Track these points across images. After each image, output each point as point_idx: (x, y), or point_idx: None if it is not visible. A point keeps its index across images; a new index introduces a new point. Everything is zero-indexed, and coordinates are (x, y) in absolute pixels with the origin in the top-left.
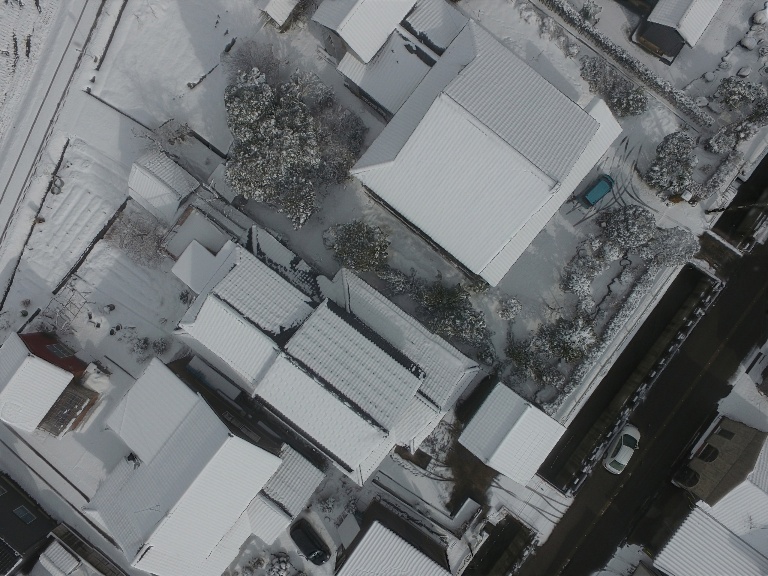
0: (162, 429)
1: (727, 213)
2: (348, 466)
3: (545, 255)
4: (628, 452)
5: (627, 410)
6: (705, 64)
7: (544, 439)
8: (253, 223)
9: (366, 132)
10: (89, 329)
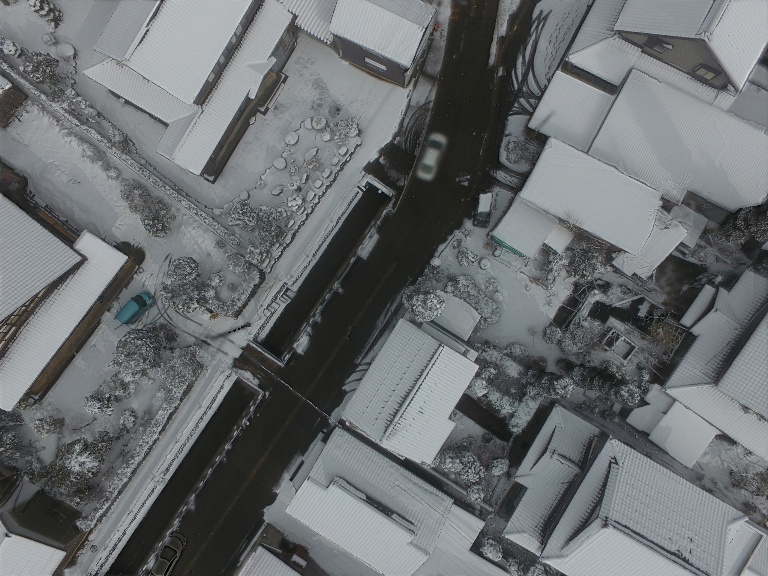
0: None
1: (285, 321)
2: None
3: (95, 370)
4: (163, 565)
5: (177, 520)
6: (247, 182)
7: (38, 564)
8: None
9: None
10: None
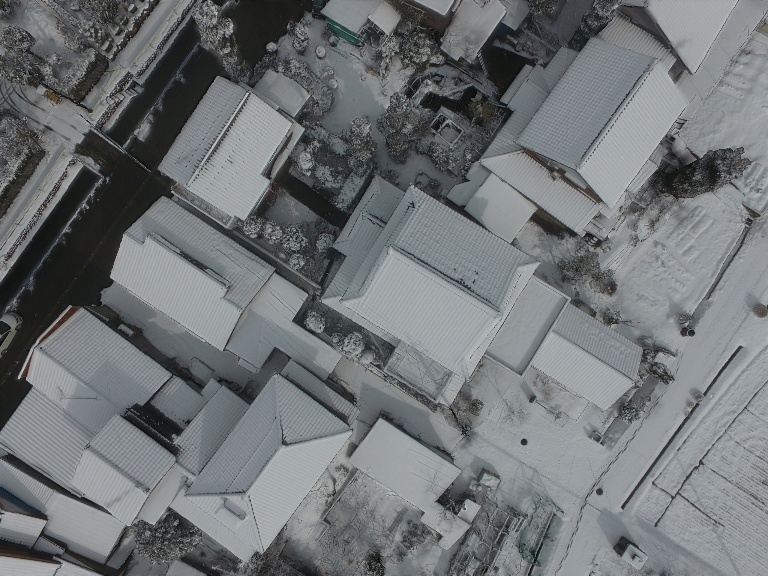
0: None
1: (132, 116)
2: None
3: None
4: None
5: (15, 300)
6: None
7: None
8: None
9: None
10: None
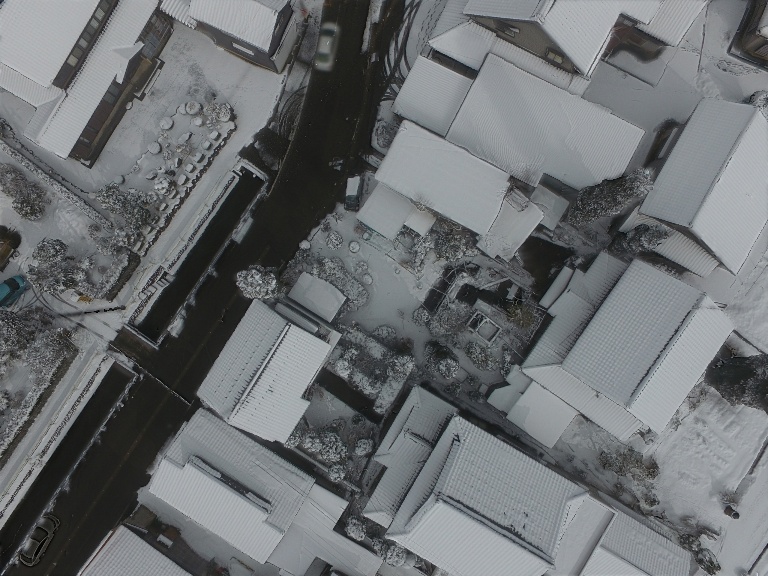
0: None
1: (164, 305)
2: None
3: None
4: (33, 545)
5: None
6: (123, 166)
7: None
8: None
9: None
10: None
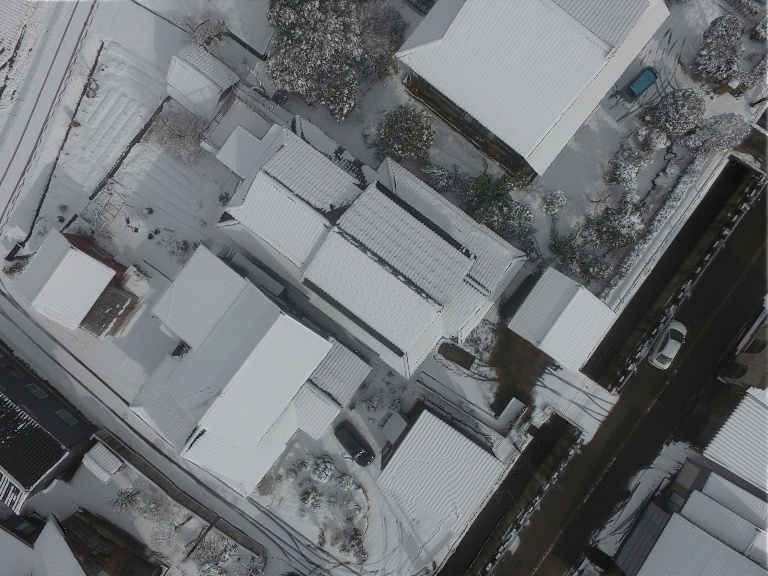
0: (210, 315)
1: None
2: (399, 349)
3: (588, 151)
4: (675, 345)
5: (672, 307)
6: None
7: (595, 324)
8: (296, 113)
9: (406, 28)
10: (127, 234)
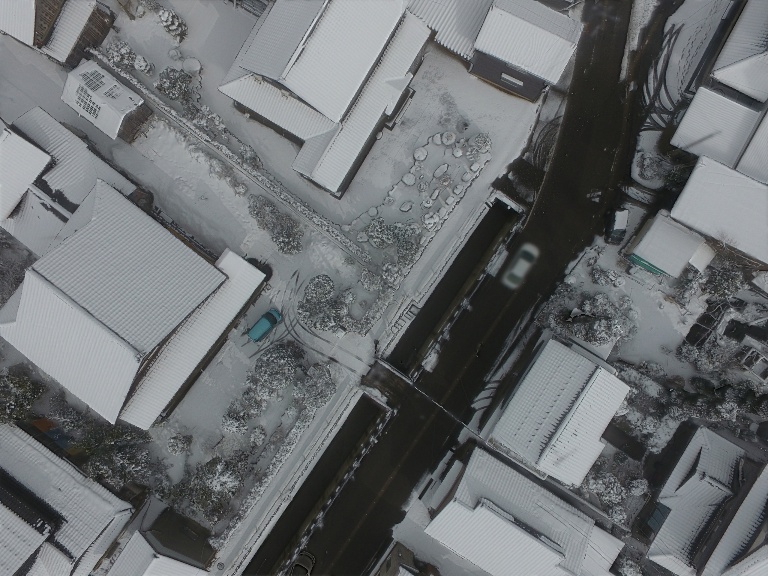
0: None
1: (408, 337)
2: None
3: (222, 387)
4: None
5: (305, 538)
6: (373, 198)
7: None
8: None
9: None
10: None
